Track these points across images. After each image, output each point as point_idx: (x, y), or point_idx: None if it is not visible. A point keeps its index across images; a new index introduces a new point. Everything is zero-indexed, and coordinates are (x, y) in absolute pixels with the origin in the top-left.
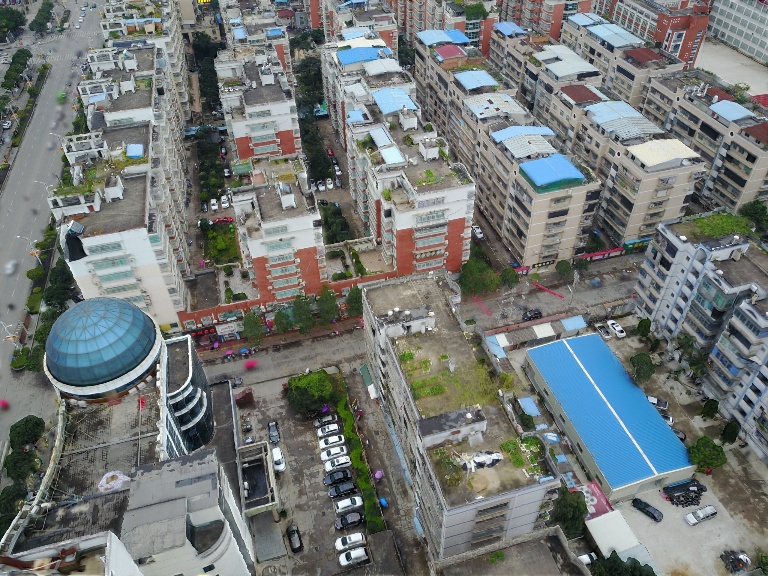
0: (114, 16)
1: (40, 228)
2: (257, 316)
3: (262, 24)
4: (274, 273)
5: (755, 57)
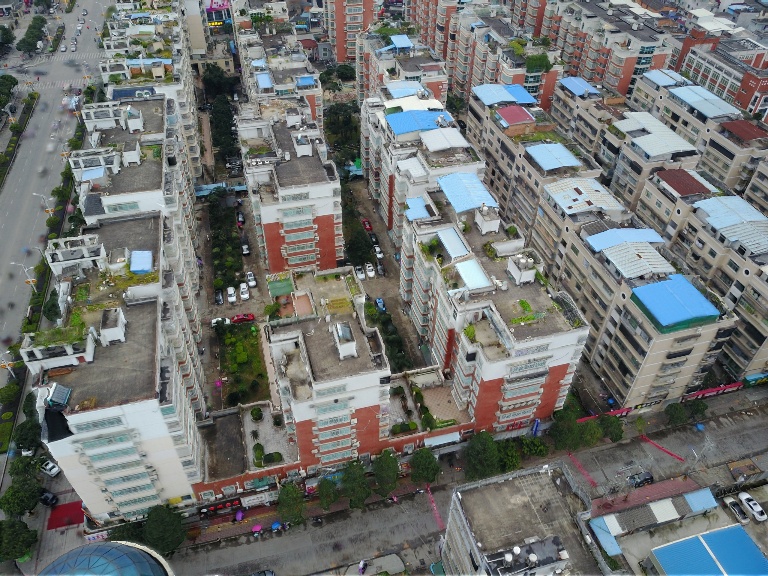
0: (115, 54)
1: (16, 319)
2: (295, 484)
3: (291, 69)
4: (322, 436)
5: None
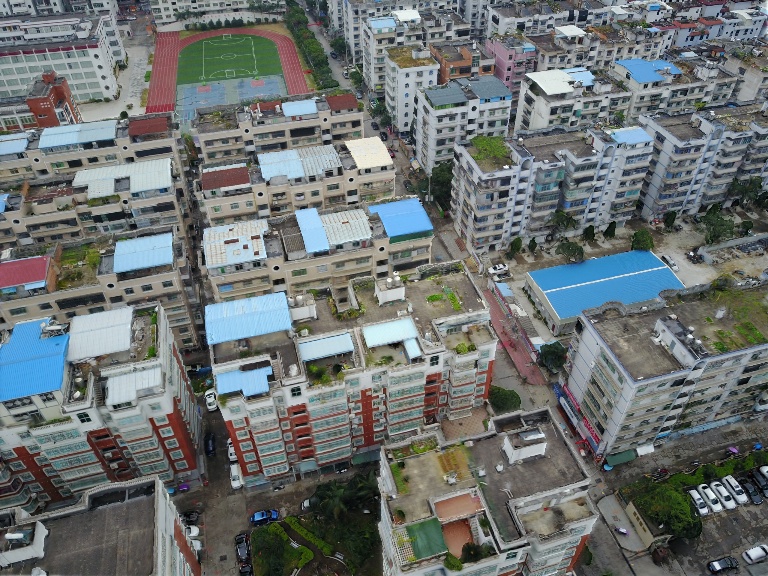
0: None
1: None
2: None
3: None
4: None
5: None
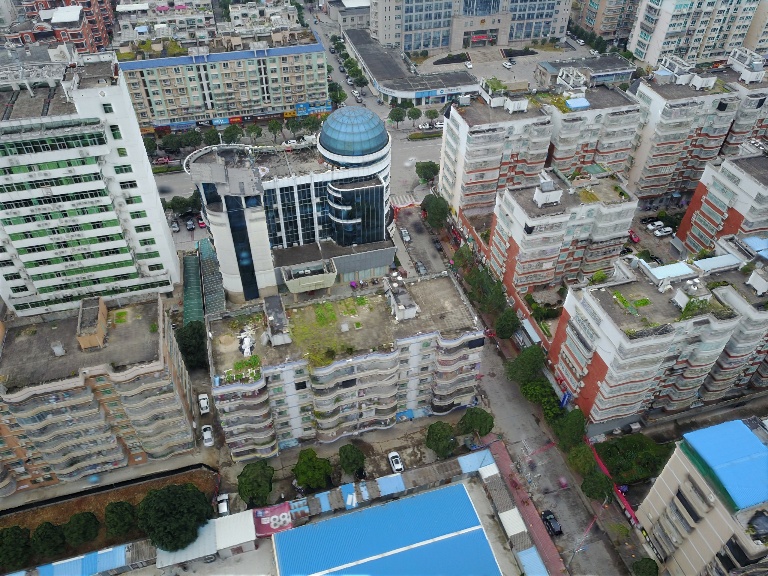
0: None
1: None
2: (476, 259)
3: None
4: (496, 238)
5: None
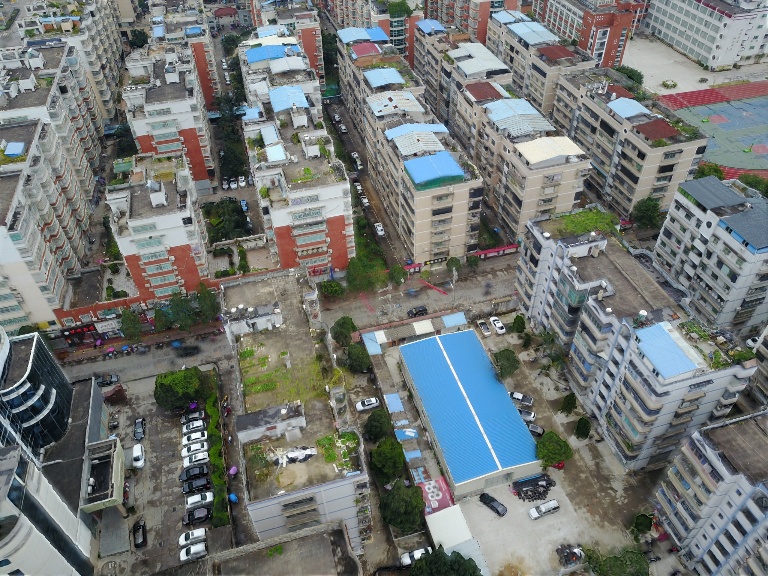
0: (33, 14)
1: None
2: (137, 313)
3: (183, 22)
4: (149, 271)
5: (688, 54)
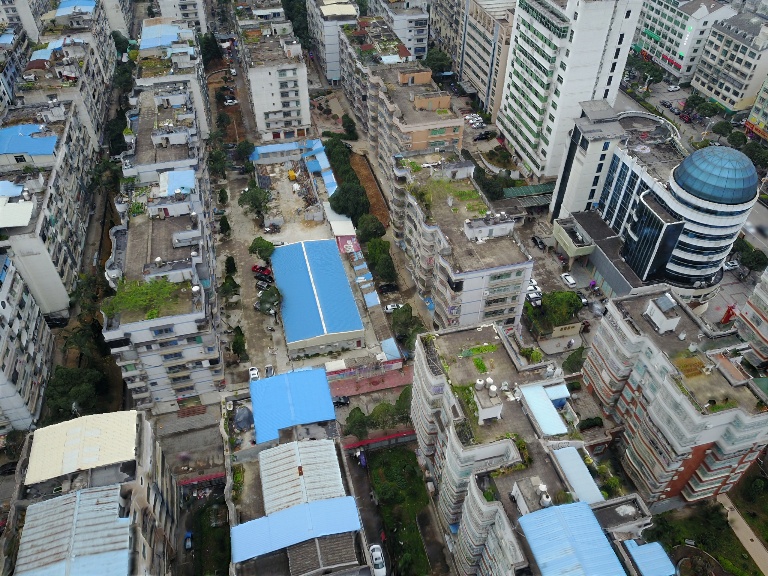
0: None
1: None
2: None
3: None
4: None
5: None
